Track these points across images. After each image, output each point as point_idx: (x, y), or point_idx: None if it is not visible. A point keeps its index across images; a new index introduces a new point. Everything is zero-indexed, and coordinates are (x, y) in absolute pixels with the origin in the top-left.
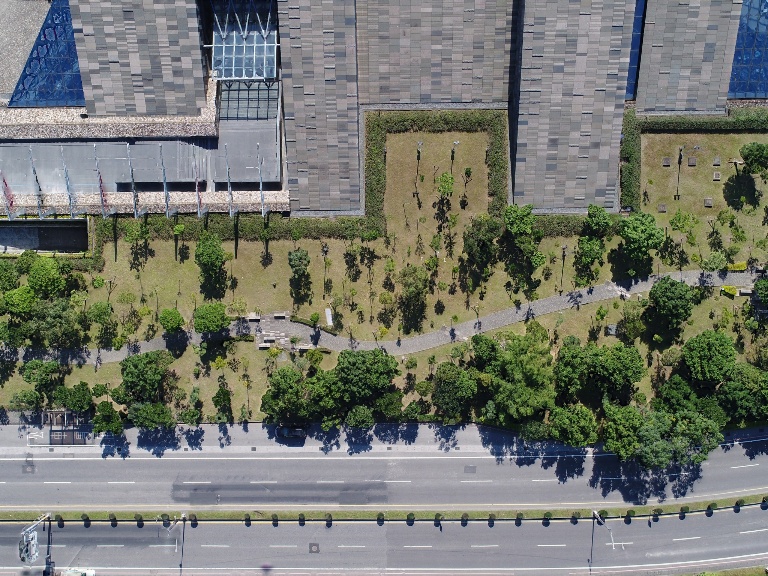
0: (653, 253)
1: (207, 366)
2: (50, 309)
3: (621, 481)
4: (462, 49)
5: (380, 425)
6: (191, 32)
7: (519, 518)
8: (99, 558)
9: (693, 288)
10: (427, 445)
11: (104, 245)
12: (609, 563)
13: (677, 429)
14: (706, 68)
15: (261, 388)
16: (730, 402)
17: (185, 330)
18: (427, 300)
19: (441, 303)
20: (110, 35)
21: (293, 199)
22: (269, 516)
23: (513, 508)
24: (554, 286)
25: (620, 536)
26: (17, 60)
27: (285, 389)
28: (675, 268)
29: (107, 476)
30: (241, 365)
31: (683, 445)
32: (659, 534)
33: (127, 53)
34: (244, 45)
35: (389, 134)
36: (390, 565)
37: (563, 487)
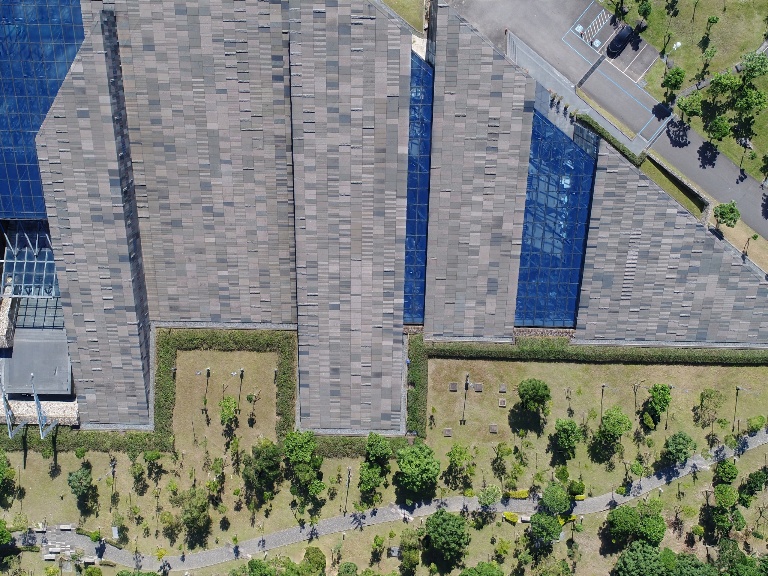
0: (437, 477)
1: None
2: None
3: None
4: (248, 275)
5: None
6: None
7: None
8: None
9: (475, 513)
10: None
11: None
12: None
13: None
14: (491, 300)
15: None
16: None
17: None
18: (213, 516)
19: (227, 519)
20: None
21: (82, 413)
22: None
23: None
24: (339, 506)
25: None
26: None
27: None
28: (458, 493)
29: None
30: None
31: None
32: None
33: None
34: (35, 262)
35: (180, 351)
36: None
37: None
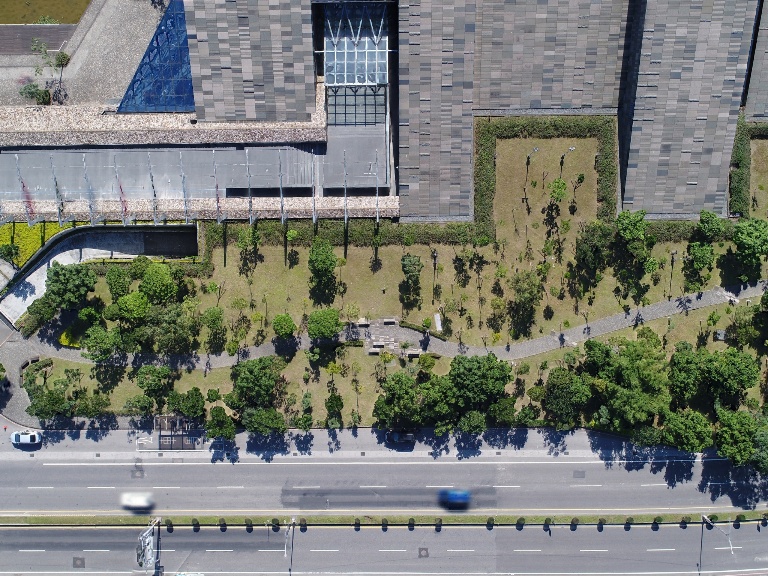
0: (762, 258)
1: (316, 371)
2: (165, 315)
3: (730, 486)
4: (575, 55)
5: (489, 430)
6: (305, 38)
7: (629, 523)
8: (208, 562)
9: None
10: (536, 450)
11: (213, 250)
12: (718, 567)
13: None
14: None
15: (370, 393)
16: None
17: (294, 335)
18: None
19: (550, 308)
20: (224, 41)
21: (403, 205)
22: (379, 521)
23: (622, 513)
24: (663, 291)
25: None
26: (123, 65)
27: (401, 395)
28: None
29: (216, 481)
30: (350, 370)
31: None
32: (767, 538)
33: (240, 59)
34: (356, 51)
35: (498, 140)
36: (499, 569)
37: (672, 492)
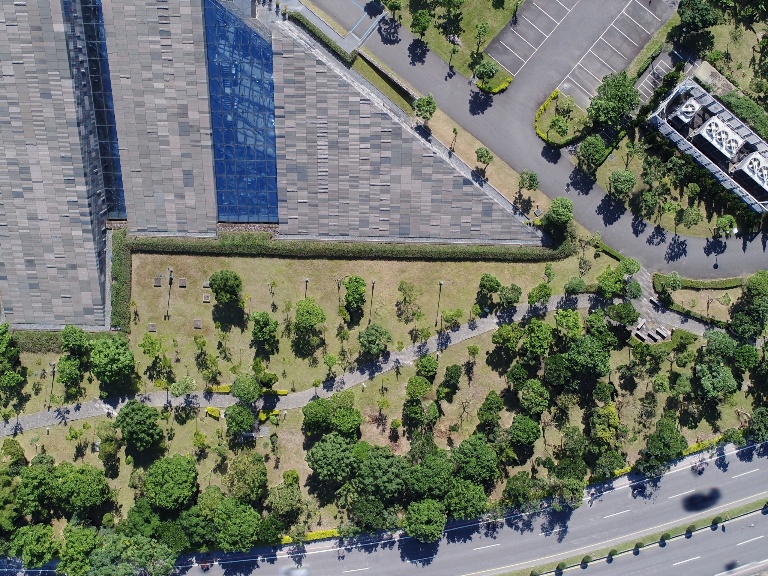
0: (142, 372)
1: None
2: None
3: None
4: None
5: None
6: None
7: None
8: None
9: (179, 408)
10: None
11: None
12: None
13: (121, 555)
14: (189, 193)
15: None
16: None
17: None
18: None
19: None
20: None
21: None
22: None
23: None
24: (44, 401)
25: None
26: None
27: None
28: (162, 388)
29: None
30: None
31: (123, 572)
32: None
33: None
34: None
35: None
36: None
37: None
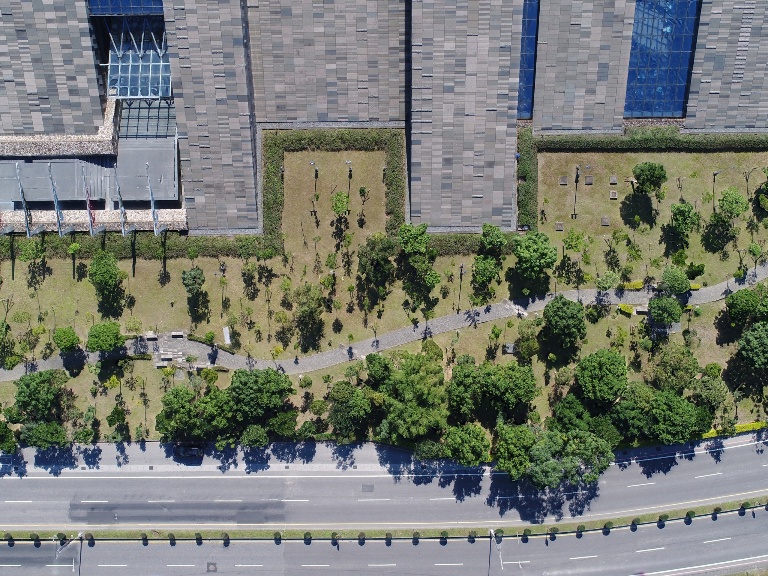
0: (550, 272)
1: (104, 385)
2: None
3: (518, 500)
4: (357, 68)
5: (278, 444)
6: (85, 51)
7: (416, 537)
8: None
9: (590, 307)
10: (325, 464)
11: (1, 263)
12: None
13: (567, 449)
14: (601, 87)
15: (159, 407)
16: (622, 421)
17: (82, 349)
18: (325, 318)
19: (339, 321)
20: (4, 54)
21: (190, 218)
22: (166, 535)
23: (410, 527)
24: (452, 304)
25: (517, 555)
26: None
27: (176, 409)
28: (572, 287)
29: (4, 495)
30: None
31: (572, 465)
32: (556, 553)
33: (22, 72)
34: (140, 64)
35: (287, 153)
36: None
37: (460, 506)
